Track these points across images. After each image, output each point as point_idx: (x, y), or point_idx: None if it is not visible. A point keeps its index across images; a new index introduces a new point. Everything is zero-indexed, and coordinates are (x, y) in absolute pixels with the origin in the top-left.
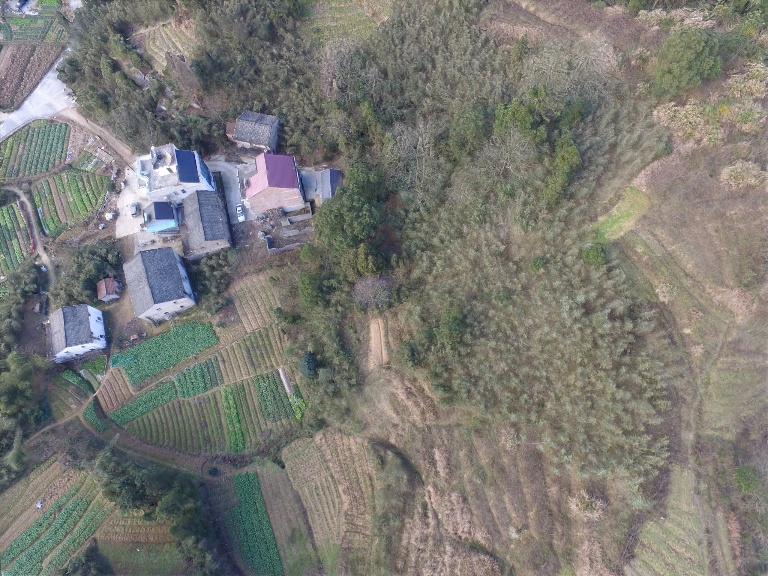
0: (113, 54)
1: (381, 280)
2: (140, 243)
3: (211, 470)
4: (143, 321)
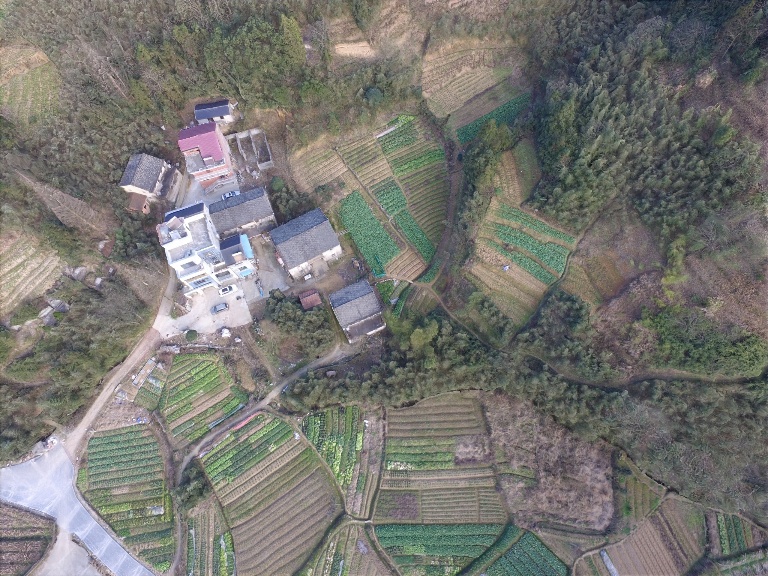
0: (5, 358)
1: (305, 42)
2: (258, 295)
3: (459, 155)
4: (340, 265)
